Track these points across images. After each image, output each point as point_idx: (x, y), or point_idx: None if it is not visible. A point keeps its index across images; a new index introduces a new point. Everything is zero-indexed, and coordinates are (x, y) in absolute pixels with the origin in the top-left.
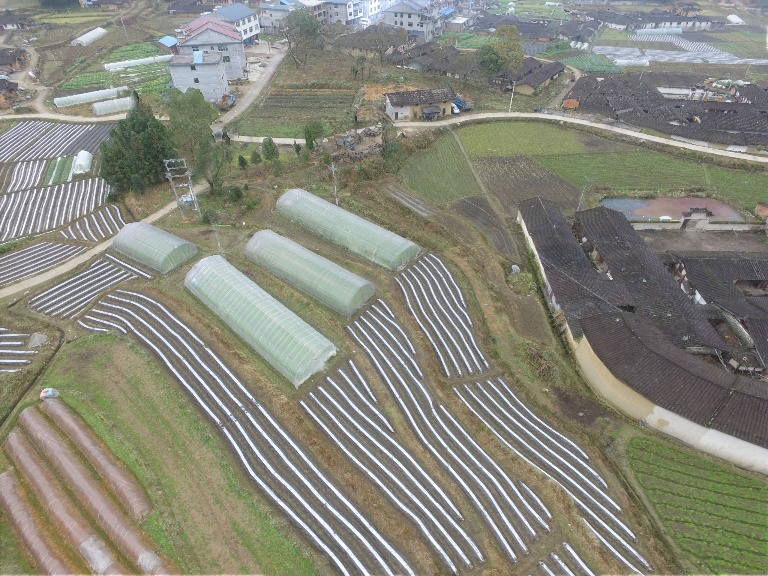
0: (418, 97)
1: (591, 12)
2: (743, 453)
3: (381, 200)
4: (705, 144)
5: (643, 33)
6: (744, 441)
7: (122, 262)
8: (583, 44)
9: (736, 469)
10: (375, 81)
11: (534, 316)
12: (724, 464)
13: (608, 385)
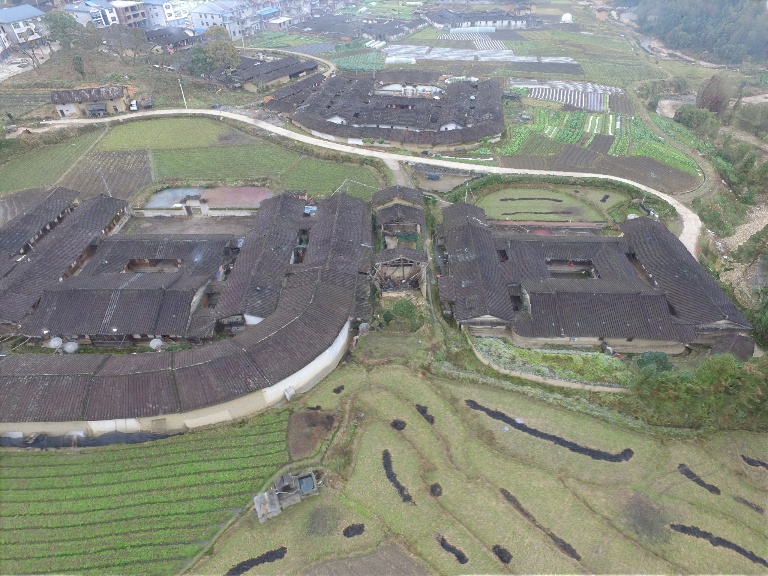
0: (82, 95)
1: (429, 11)
2: None
3: None
4: (332, 137)
5: (456, 32)
6: None
7: None
8: (379, 43)
9: None
10: (97, 80)
11: None
12: None
13: None
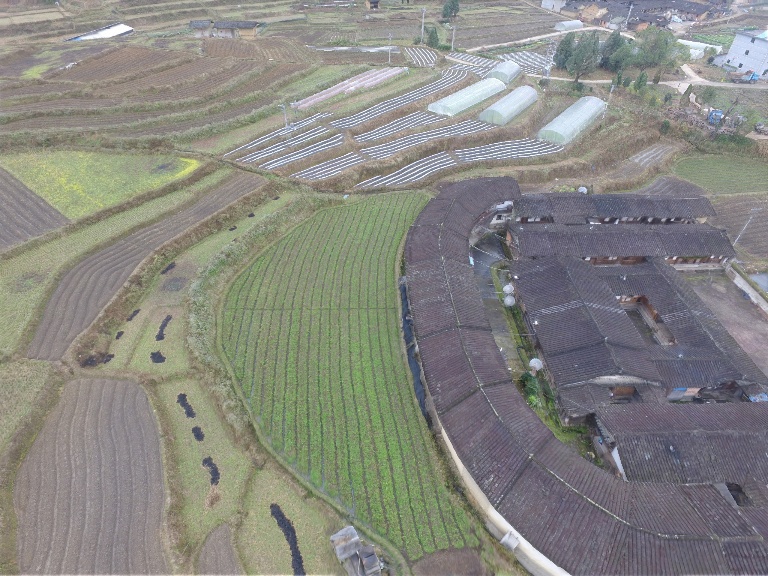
0: None
1: None
2: None
3: None
4: None
5: None
6: None
7: None
8: None
9: None
10: None
11: (528, 191)
12: None
13: None
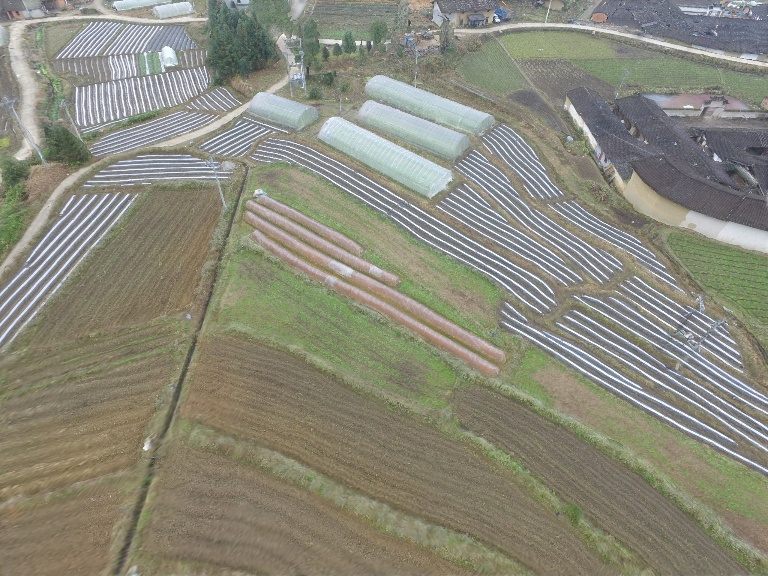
0: (465, 5)
1: None
2: (747, 241)
3: (451, 87)
4: (721, 53)
5: None
6: (750, 227)
7: (260, 122)
8: None
9: (742, 249)
10: None
11: (589, 169)
12: (734, 246)
13: (651, 206)
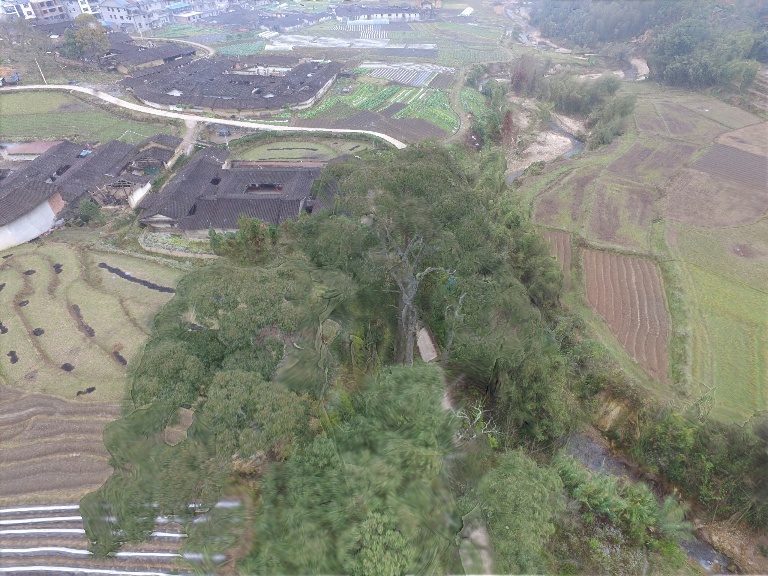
0: None
1: (339, 6)
2: None
3: None
4: (158, 105)
5: (352, 24)
6: None
7: None
8: (271, 33)
9: None
10: None
11: None
12: None
13: None
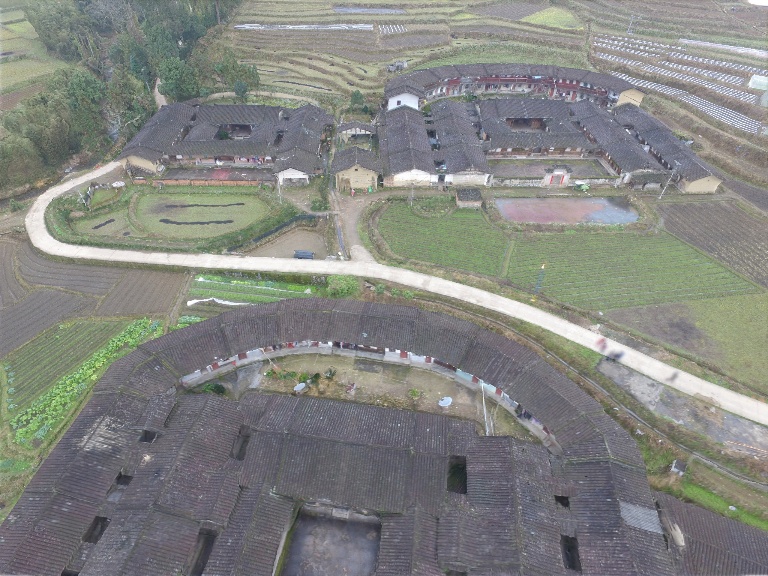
0: None
1: None
2: None
3: None
4: None
5: None
6: None
7: None
8: None
9: None
10: None
11: (664, 123)
12: None
13: None
